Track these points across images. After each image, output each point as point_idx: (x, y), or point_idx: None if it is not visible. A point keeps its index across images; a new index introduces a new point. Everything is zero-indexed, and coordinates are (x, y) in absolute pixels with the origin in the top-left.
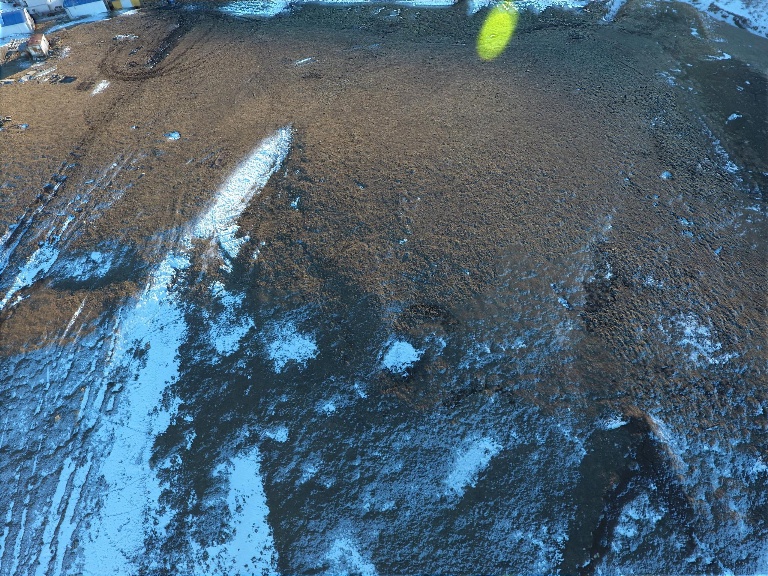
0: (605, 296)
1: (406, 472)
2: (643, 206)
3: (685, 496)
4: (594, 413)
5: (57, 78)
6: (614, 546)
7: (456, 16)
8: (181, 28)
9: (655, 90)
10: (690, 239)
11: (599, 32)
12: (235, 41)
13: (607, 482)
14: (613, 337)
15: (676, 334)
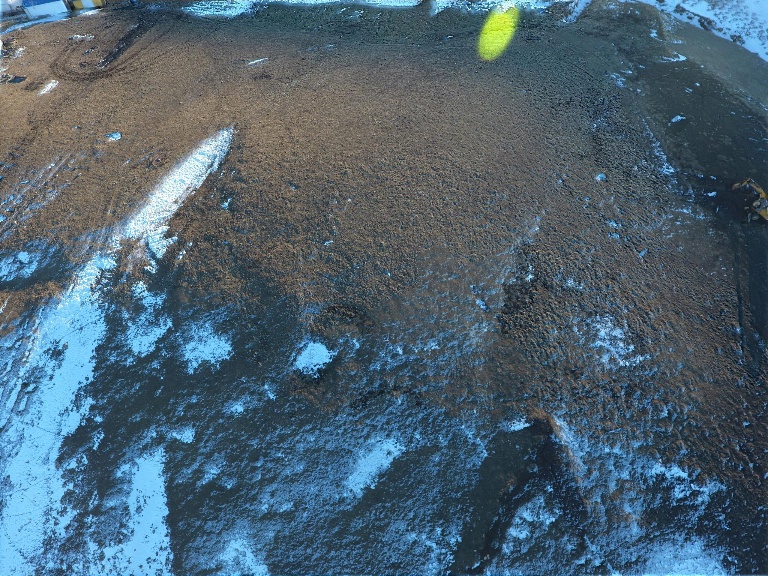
0: (523, 298)
1: (307, 473)
2: (573, 208)
3: (581, 498)
4: (499, 415)
5: (6, 78)
6: (505, 548)
7: (417, 17)
8: (140, 28)
9: (602, 92)
10: (616, 241)
11: (555, 33)
12: (191, 41)
13: (504, 484)
14: (526, 339)
15: (590, 336)
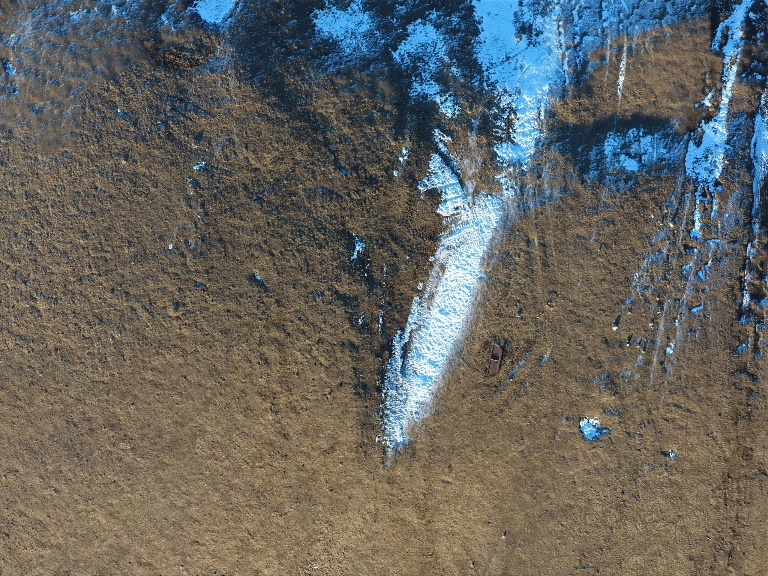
0: None
1: None
2: None
3: None
4: None
5: None
6: None
7: None
8: None
9: None
10: None
11: None
12: None
13: None
14: None
15: None
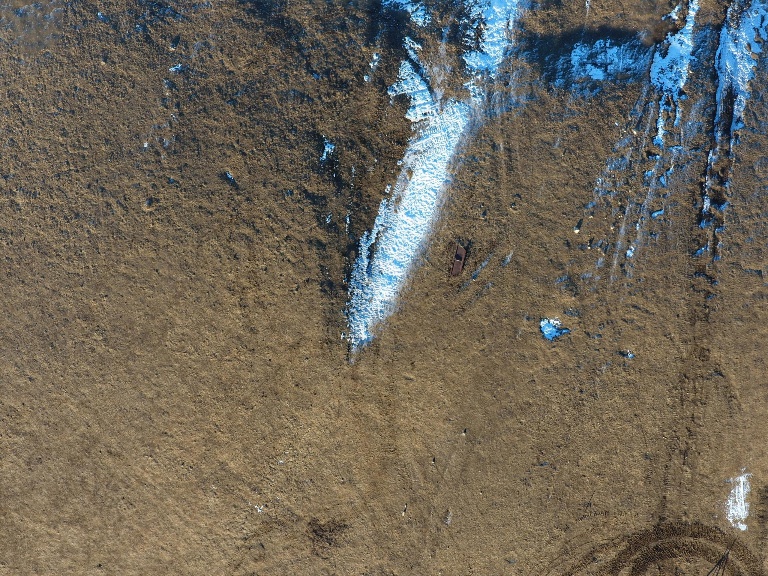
0: None
1: None
2: None
3: None
4: None
5: None
6: None
7: None
8: None
9: None
10: None
11: None
12: None
13: None
14: None
15: None
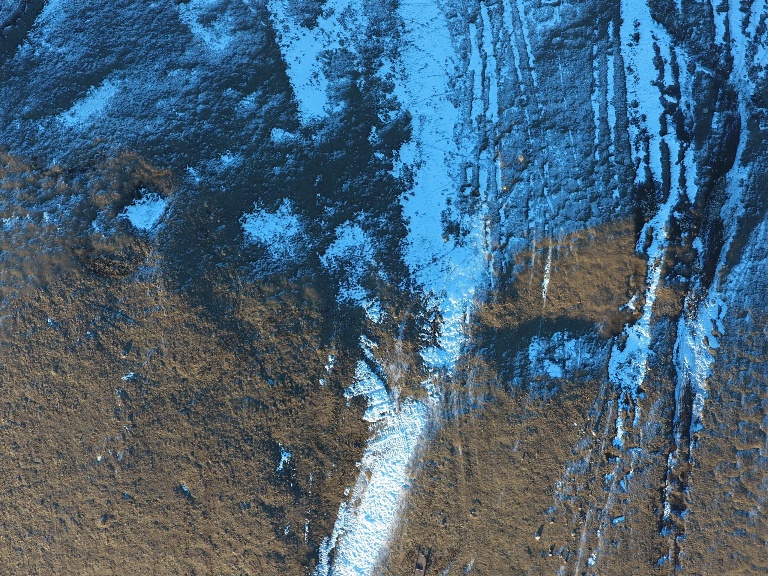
0: None
1: (154, 98)
2: None
3: None
4: None
5: None
6: None
7: None
8: None
9: None
10: None
11: None
12: None
13: None
14: None
15: None
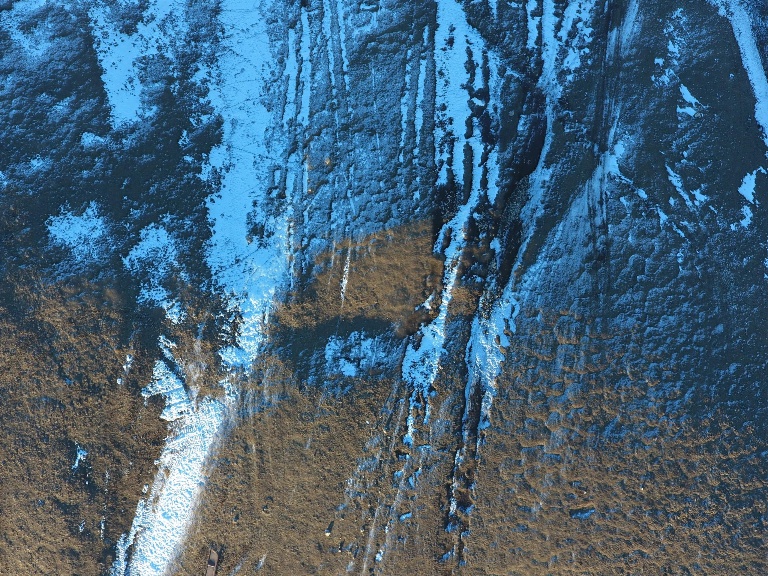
0: None
1: None
2: None
3: None
4: None
5: None
6: None
7: None
8: None
9: None
10: None
11: None
12: None
13: None
14: None
15: None
